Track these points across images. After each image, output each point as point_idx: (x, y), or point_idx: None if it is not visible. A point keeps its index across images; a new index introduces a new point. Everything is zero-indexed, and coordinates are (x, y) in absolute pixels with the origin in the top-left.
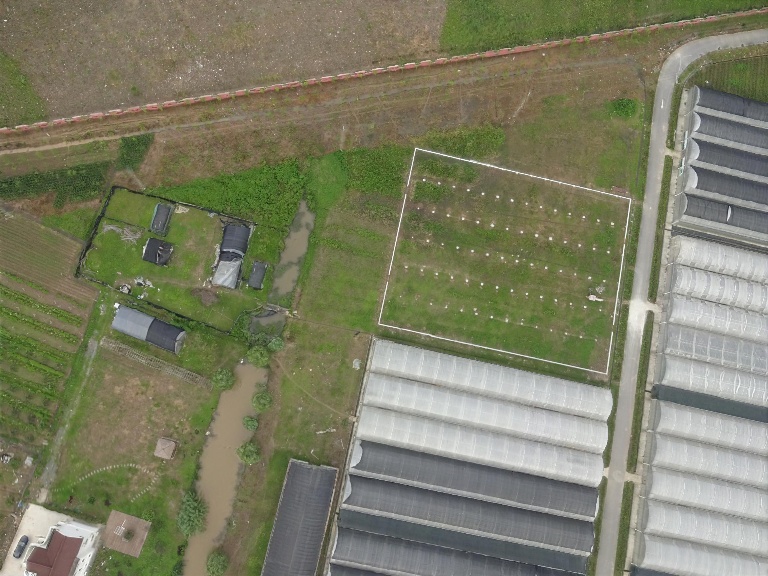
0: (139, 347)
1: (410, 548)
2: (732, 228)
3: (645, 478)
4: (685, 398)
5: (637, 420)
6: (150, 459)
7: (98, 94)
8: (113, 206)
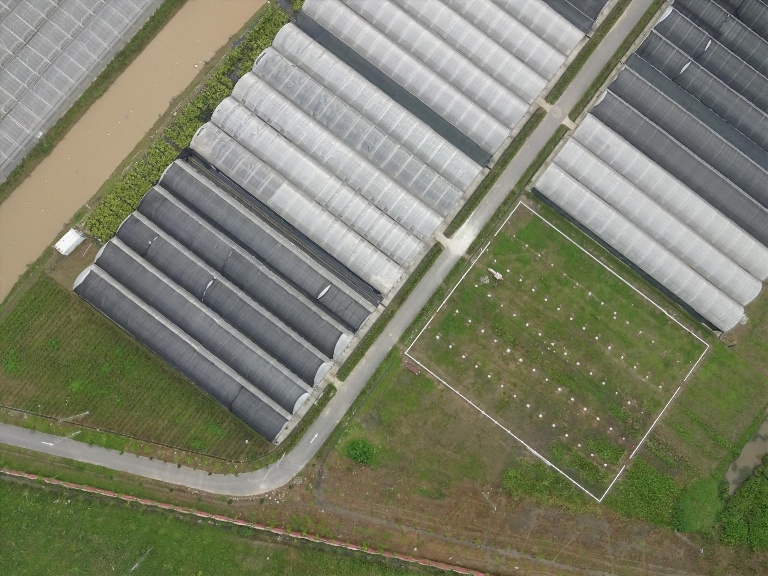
0: None
1: None
2: (326, 276)
3: None
4: (461, 145)
5: (515, 149)
6: None
7: None
8: None
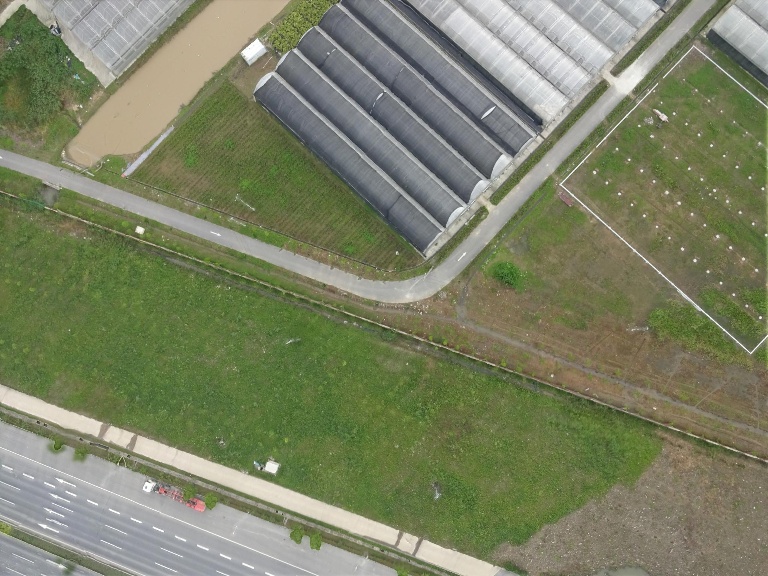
0: None
1: None
2: (491, 99)
3: None
4: None
5: None
6: None
7: None
8: None
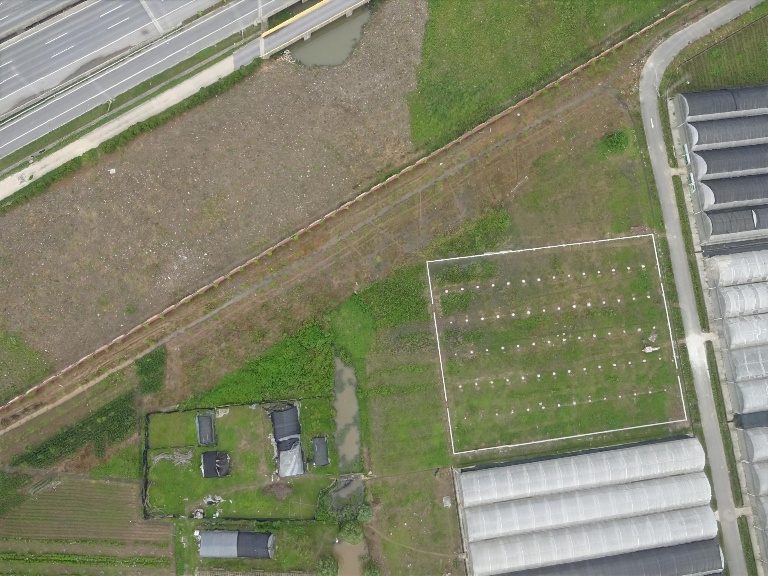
0: (234, 565)
1: None
2: (761, 231)
3: (755, 509)
4: None
5: (729, 455)
6: None
7: (94, 326)
8: (154, 434)
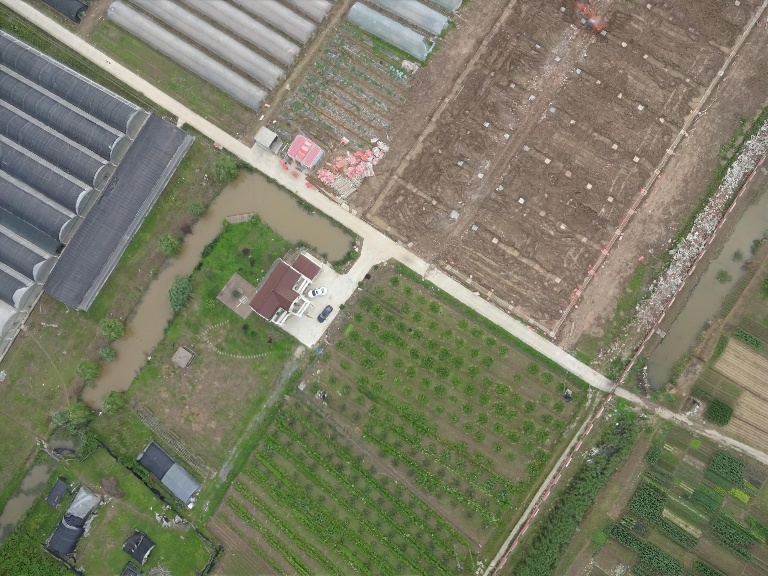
0: None
1: (6, 204)
2: None
3: None
4: None
5: None
6: (203, 352)
7: None
8: None
